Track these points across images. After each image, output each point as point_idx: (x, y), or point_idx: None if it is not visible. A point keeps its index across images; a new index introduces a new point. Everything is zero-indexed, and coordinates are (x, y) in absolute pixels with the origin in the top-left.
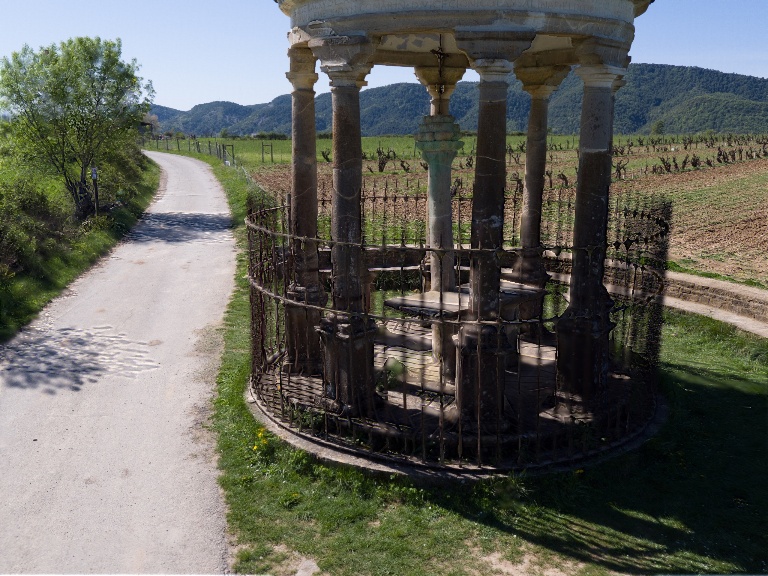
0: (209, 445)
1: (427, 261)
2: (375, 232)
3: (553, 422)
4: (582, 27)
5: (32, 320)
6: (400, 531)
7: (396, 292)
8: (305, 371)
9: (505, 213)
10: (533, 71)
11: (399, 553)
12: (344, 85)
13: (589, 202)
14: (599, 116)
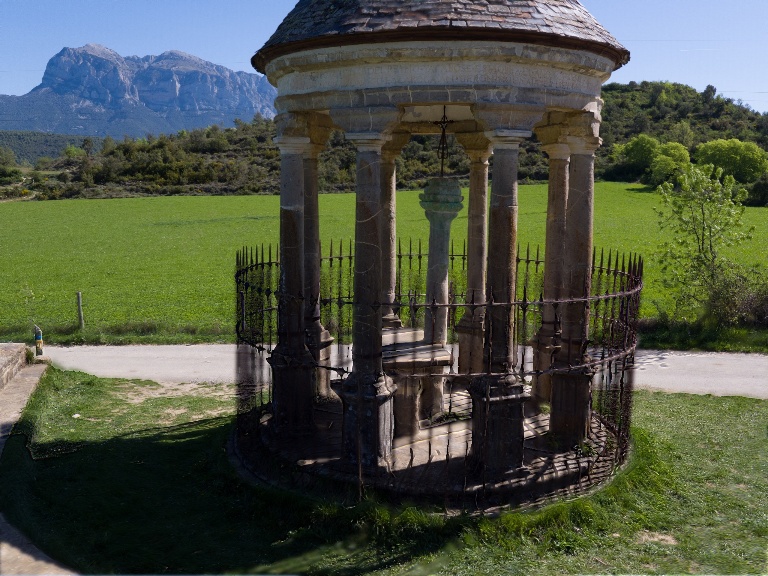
0: None
1: None
2: None
3: None
4: None
5: (688, 351)
6: None
7: None
8: None
9: None
10: None
11: None
12: None
13: None
14: None
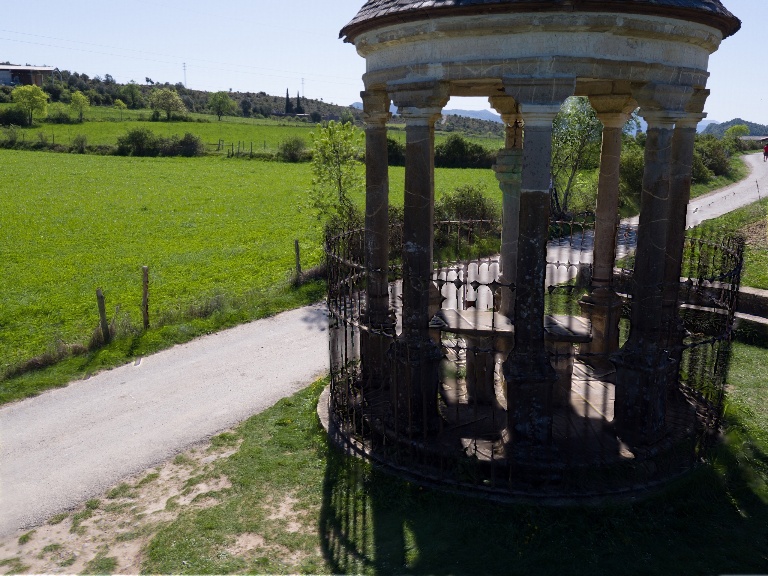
0: (314, 381)
1: None
2: (759, 268)
3: (457, 446)
4: (486, 71)
5: None
6: (285, 461)
7: None
8: None
9: None
10: None
11: (262, 469)
12: (369, 128)
13: (520, 242)
14: (527, 156)
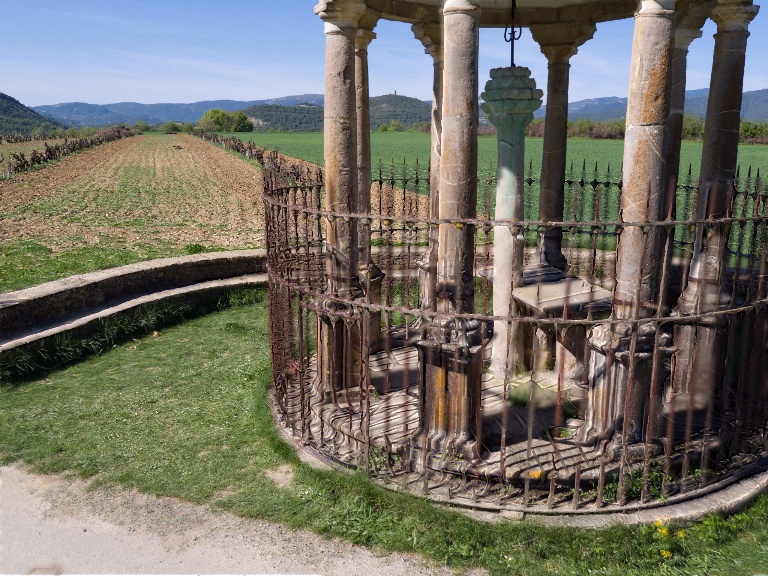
0: None
1: (362, 268)
2: None
3: None
4: None
5: None
6: None
7: (141, 343)
8: (485, 444)
9: (21, 225)
10: None
11: None
12: None
13: None
14: None
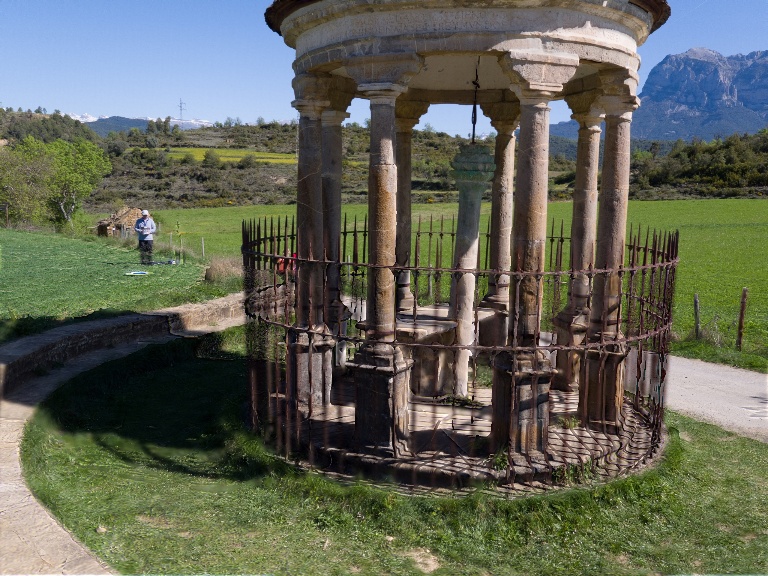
0: None
1: None
2: None
3: None
4: None
5: None
6: None
7: None
8: None
9: None
10: None
11: None
12: None
13: None
14: None
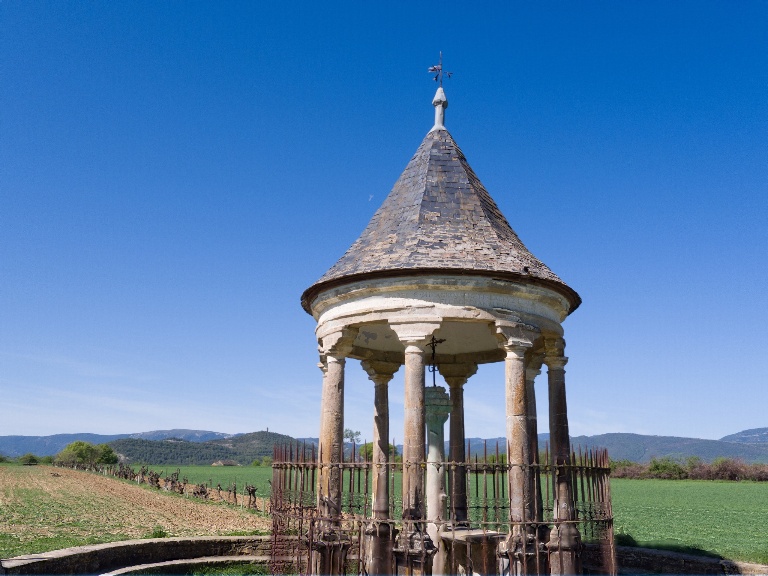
0: None
1: None
2: None
3: None
4: None
5: None
6: None
7: None
8: None
9: None
10: (385, 364)
11: None
12: None
13: None
14: None
